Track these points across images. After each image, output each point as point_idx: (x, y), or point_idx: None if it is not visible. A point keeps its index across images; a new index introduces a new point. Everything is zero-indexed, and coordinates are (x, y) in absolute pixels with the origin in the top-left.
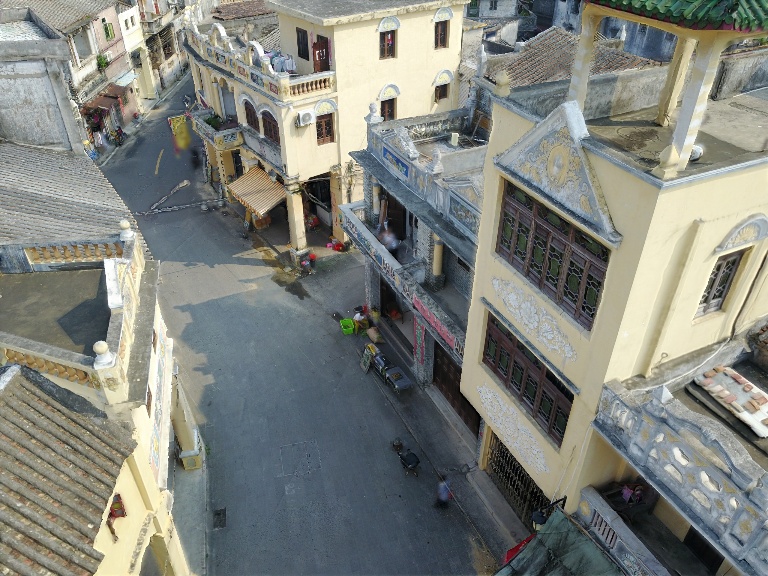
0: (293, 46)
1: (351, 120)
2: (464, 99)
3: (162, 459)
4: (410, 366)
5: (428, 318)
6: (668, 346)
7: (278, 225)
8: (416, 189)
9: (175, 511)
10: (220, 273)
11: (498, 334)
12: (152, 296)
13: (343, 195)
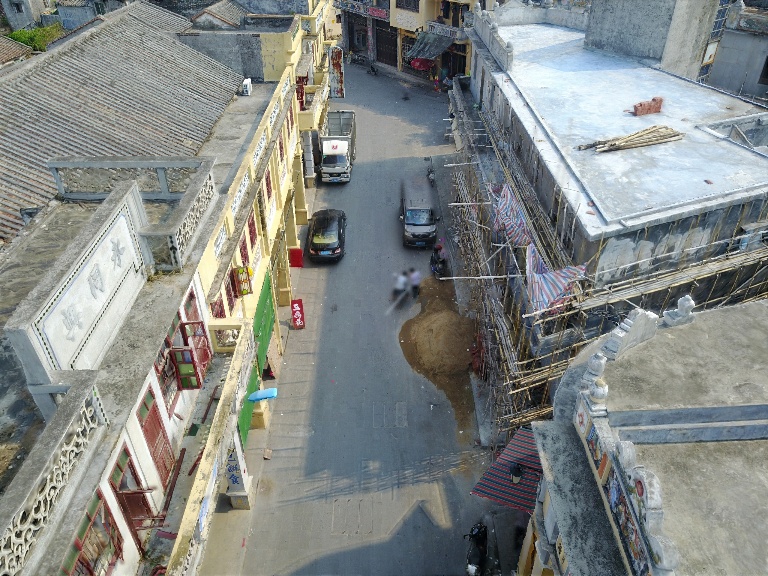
0: None
1: None
2: None
3: None
4: None
5: (375, 15)
6: None
7: None
8: None
9: None
10: None
11: None
12: None
13: None
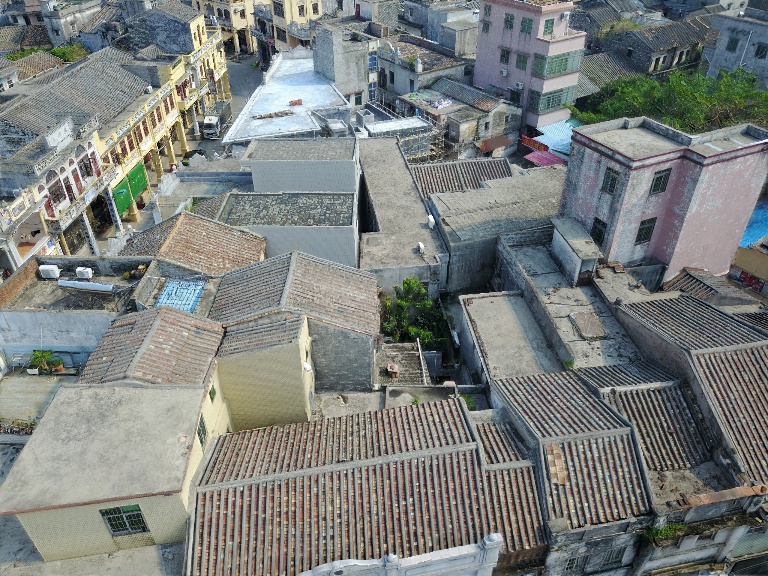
0: None
1: (250, 12)
2: None
3: None
4: None
5: (270, 42)
6: None
7: (229, 52)
8: (265, 16)
9: None
10: None
11: (278, 31)
12: None
13: (250, 36)
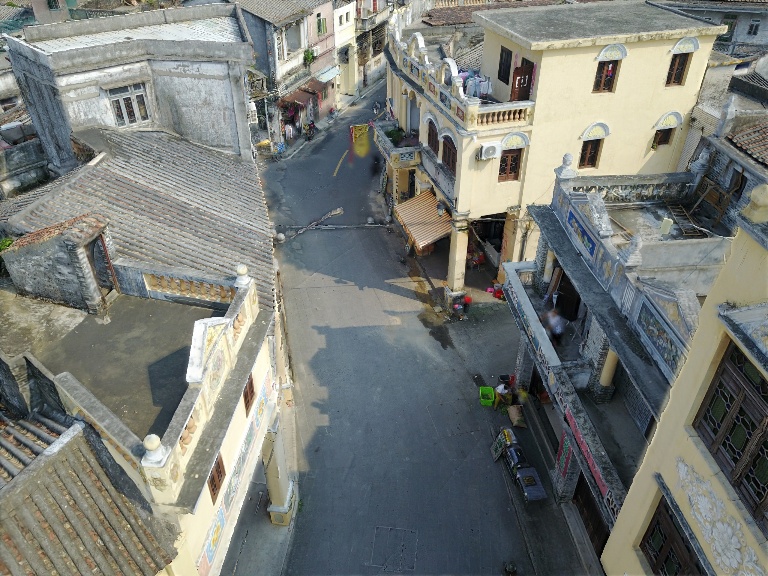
0: (494, 66)
1: (543, 158)
2: (691, 148)
3: (220, 551)
4: (549, 468)
5: (580, 442)
6: None
7: (441, 254)
8: (600, 274)
9: (249, 570)
10: (367, 298)
11: (670, 529)
12: (251, 359)
13: (516, 240)
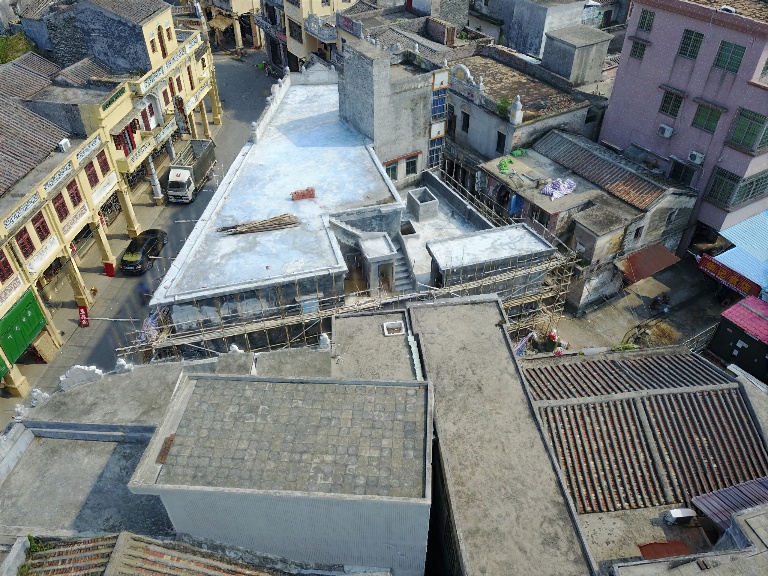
0: None
1: None
2: None
3: None
4: (282, 73)
5: (280, 38)
6: (317, 12)
7: (229, 44)
8: (275, 0)
9: None
10: None
11: (291, 24)
12: None
13: None
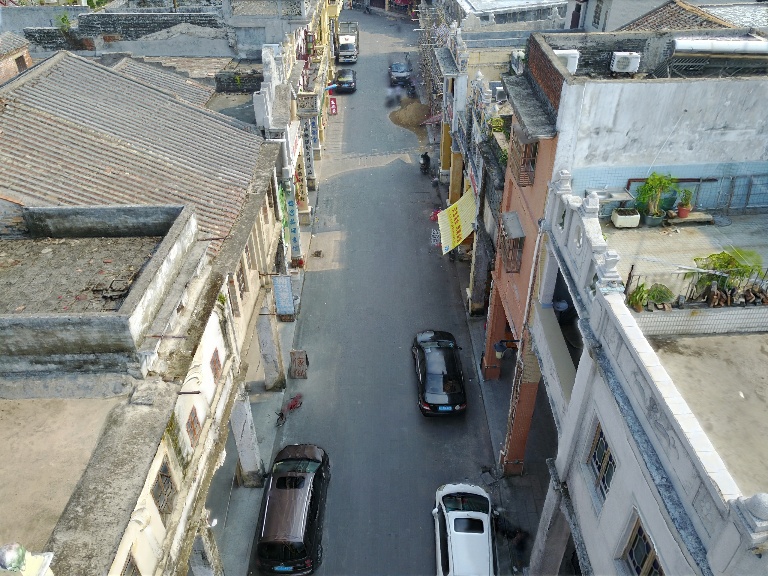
0: None
1: None
2: None
3: None
4: None
5: None
6: None
7: None
8: None
9: None
10: None
11: None
12: None
13: None
